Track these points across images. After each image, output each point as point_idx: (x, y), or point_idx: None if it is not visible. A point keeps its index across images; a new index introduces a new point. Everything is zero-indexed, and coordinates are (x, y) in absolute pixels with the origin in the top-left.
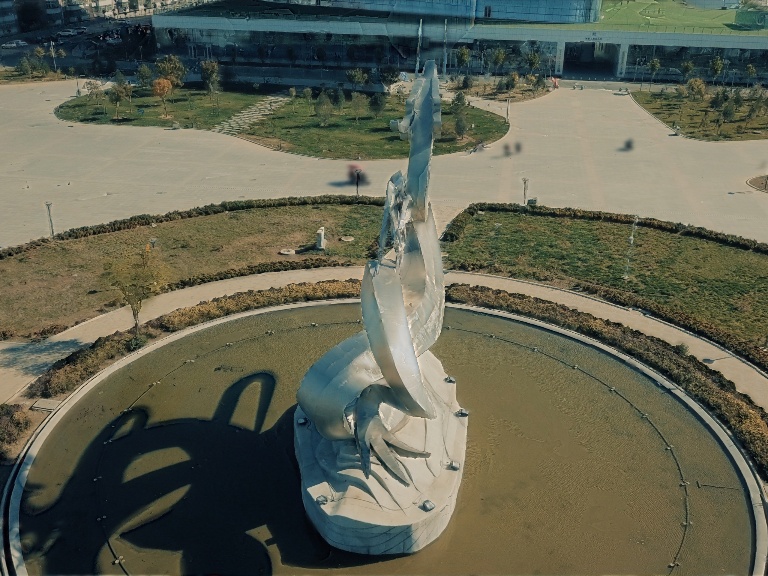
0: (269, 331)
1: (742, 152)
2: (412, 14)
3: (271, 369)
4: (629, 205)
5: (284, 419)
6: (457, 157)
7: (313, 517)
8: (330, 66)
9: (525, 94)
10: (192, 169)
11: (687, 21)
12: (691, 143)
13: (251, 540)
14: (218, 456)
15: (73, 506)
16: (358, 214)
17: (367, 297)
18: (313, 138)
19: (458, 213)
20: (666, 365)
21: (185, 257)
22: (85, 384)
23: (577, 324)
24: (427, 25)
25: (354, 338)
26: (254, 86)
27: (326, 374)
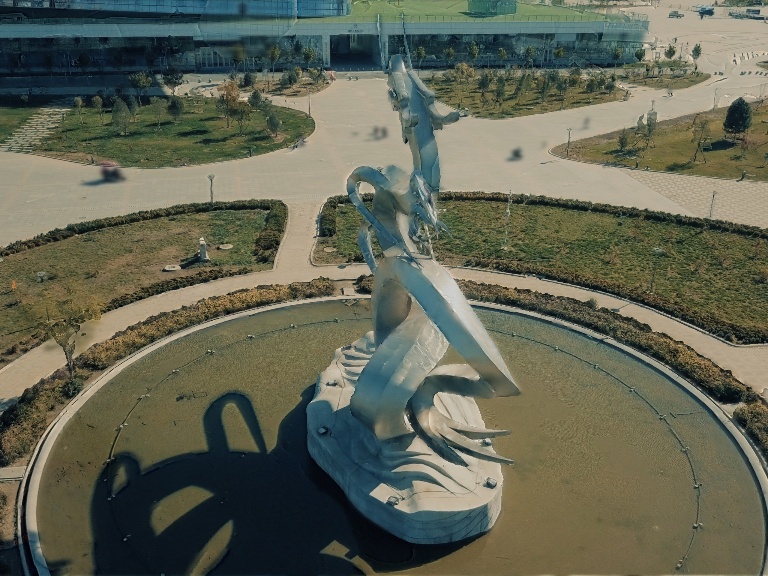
0: (209, 351)
1: (529, 126)
2: (228, 12)
3: (236, 388)
4: (468, 183)
5: (283, 434)
6: (283, 154)
7: (381, 521)
8: (91, 72)
9: (308, 88)
10: (4, 194)
11: (426, 11)
12: (483, 122)
13: (331, 558)
14: (237, 486)
15: (117, 573)
16: (221, 221)
17: (425, 291)
18: (122, 148)
19: (319, 208)
20: (589, 319)
21: (61, 289)
22: (41, 442)
23: (493, 296)
24: (246, 23)
25: (395, 335)
26: (22, 98)
27: (382, 375)
